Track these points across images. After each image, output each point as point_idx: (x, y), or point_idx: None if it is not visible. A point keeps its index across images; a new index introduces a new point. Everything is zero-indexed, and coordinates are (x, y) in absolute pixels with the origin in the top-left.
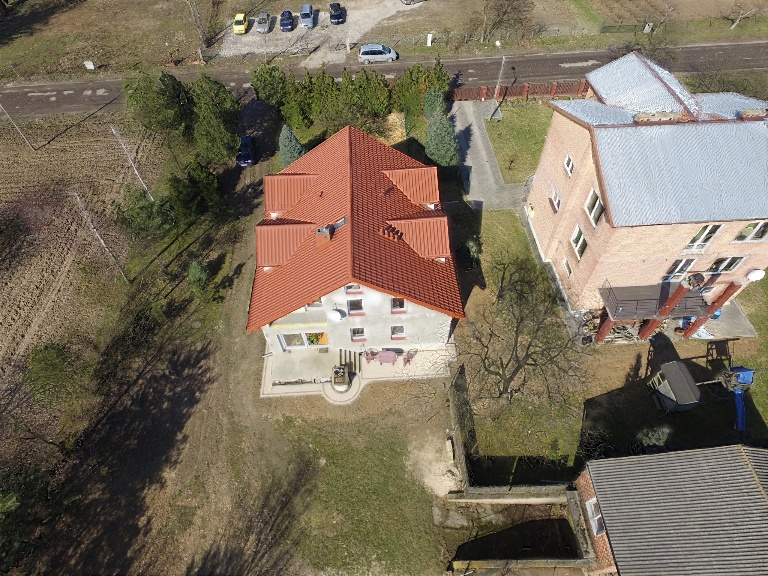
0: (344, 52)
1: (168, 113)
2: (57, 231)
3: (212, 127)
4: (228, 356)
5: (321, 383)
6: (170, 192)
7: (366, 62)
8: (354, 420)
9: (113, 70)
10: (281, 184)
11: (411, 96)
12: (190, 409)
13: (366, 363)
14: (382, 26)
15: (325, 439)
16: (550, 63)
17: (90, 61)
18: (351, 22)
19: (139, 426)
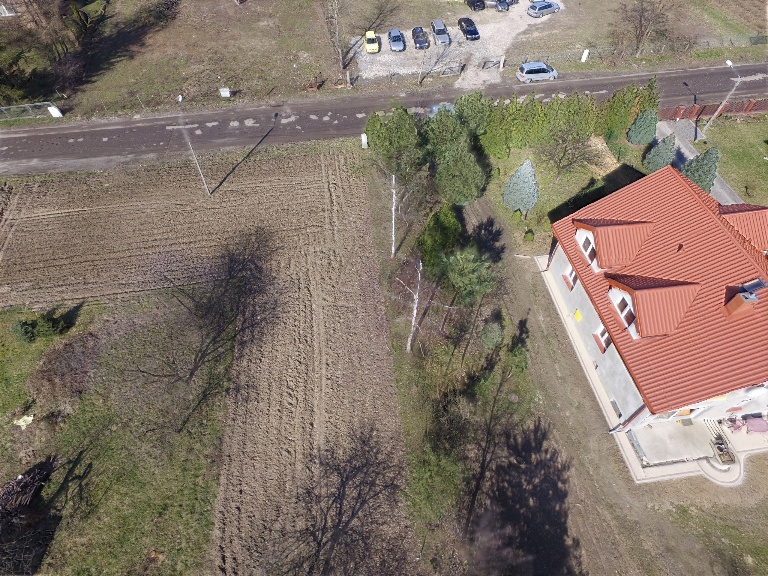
0: (496, 70)
1: (417, 153)
2: (287, 291)
3: (468, 167)
4: (568, 434)
5: (695, 461)
6: (416, 241)
7: (528, 81)
8: (754, 504)
9: (249, 97)
10: (616, 235)
11: (620, 120)
12: (562, 505)
13: (730, 432)
14: (521, 41)
15: (735, 530)
16: (720, 78)
17: (227, 88)
18: (486, 37)
19: (515, 531)
